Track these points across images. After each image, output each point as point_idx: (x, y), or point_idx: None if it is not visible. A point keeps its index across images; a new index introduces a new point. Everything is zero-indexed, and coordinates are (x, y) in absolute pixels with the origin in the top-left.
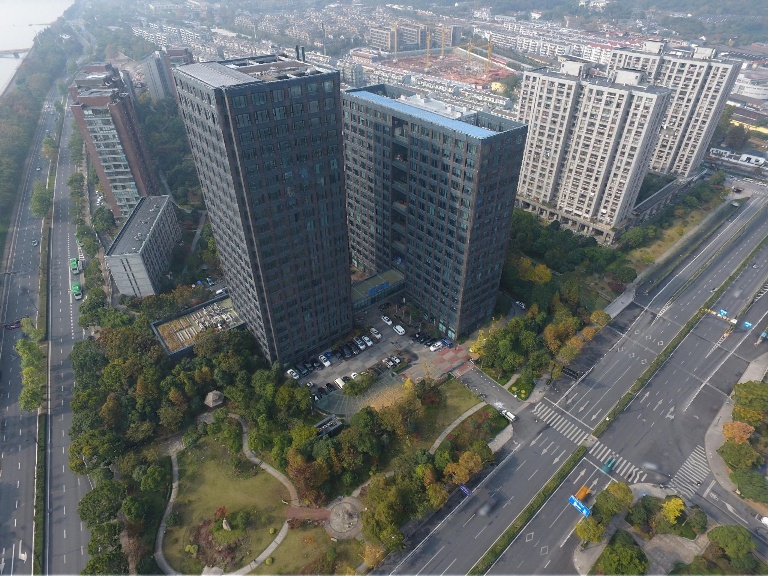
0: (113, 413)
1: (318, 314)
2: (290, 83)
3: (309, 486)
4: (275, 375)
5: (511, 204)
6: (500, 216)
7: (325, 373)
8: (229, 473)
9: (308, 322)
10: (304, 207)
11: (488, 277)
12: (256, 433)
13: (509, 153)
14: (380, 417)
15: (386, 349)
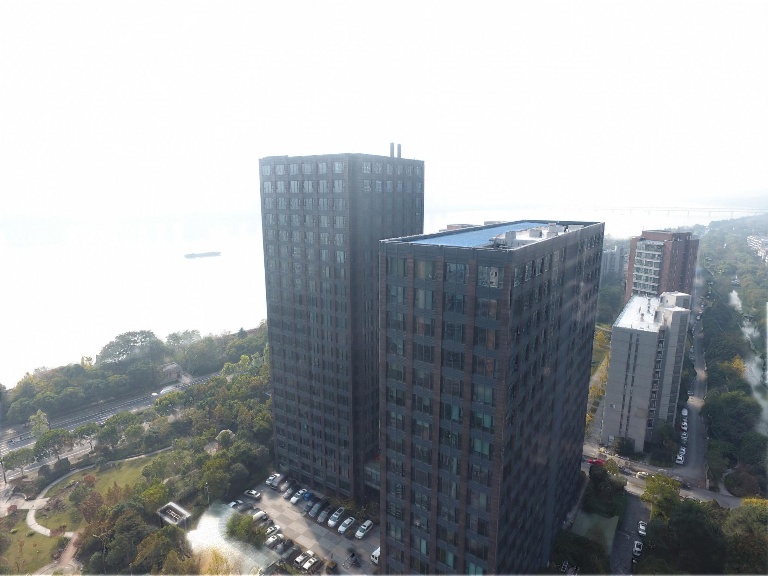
0: (198, 393)
1: (315, 435)
2: (304, 159)
3: (90, 523)
4: (245, 453)
5: (494, 430)
6: (461, 438)
7: (280, 503)
8: (142, 477)
9: (305, 435)
10: (309, 292)
11: (450, 573)
12: (159, 460)
13: (462, 297)
14: (148, 538)
15: (337, 551)
